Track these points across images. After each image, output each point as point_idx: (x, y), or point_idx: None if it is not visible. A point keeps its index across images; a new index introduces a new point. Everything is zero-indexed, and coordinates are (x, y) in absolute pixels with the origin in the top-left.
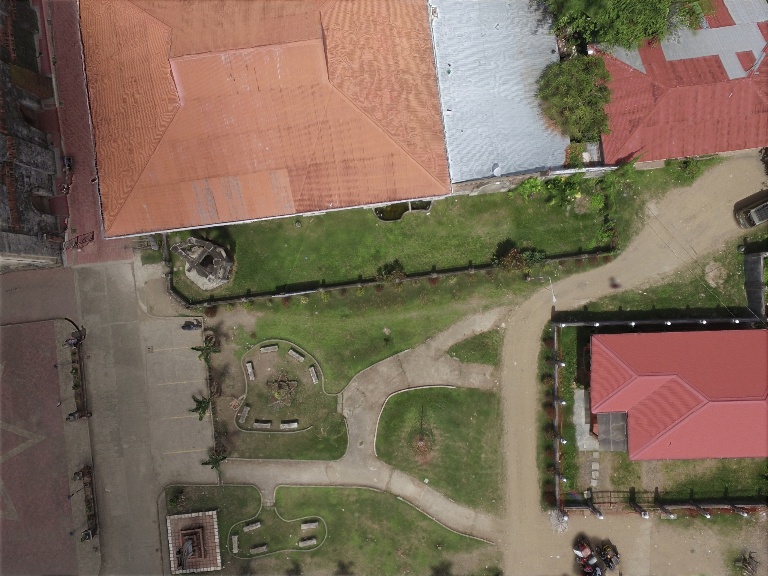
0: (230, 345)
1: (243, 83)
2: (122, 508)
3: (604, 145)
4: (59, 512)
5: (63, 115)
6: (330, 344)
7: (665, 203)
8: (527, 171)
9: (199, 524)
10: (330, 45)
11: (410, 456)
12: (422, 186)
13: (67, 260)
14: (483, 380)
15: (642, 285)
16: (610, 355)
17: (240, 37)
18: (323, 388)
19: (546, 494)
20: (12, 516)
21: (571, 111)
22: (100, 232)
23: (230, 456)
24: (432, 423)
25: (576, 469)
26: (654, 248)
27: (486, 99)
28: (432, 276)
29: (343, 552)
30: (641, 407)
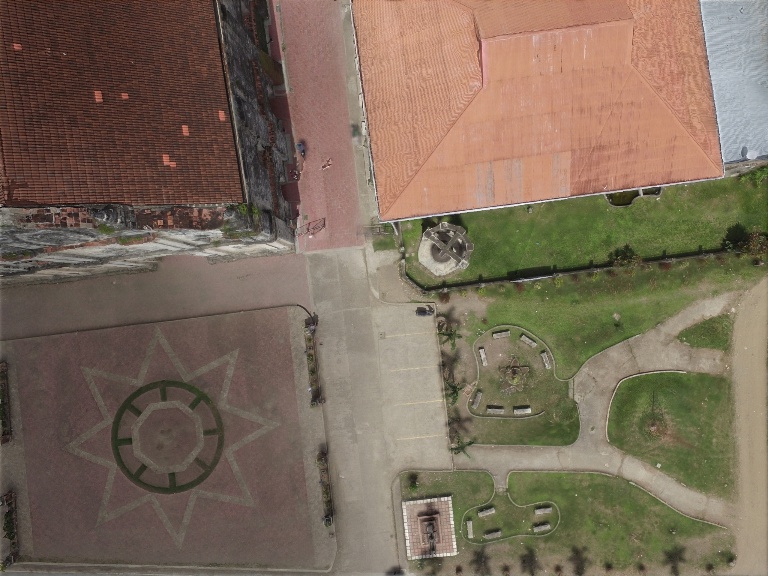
0: (462, 331)
1: (547, 64)
2: (356, 494)
3: None
4: (295, 498)
5: (293, 101)
6: (561, 329)
7: None
8: None
9: (435, 510)
10: None
11: (642, 441)
12: (697, 168)
13: (299, 246)
14: (713, 365)
15: None
16: None
17: (547, 18)
18: (555, 373)
19: None
20: (248, 503)
21: None
22: (331, 218)
23: None
24: (663, 408)
25: None
26: None
27: (735, 83)
28: (667, 261)
29: (577, 537)
30: None
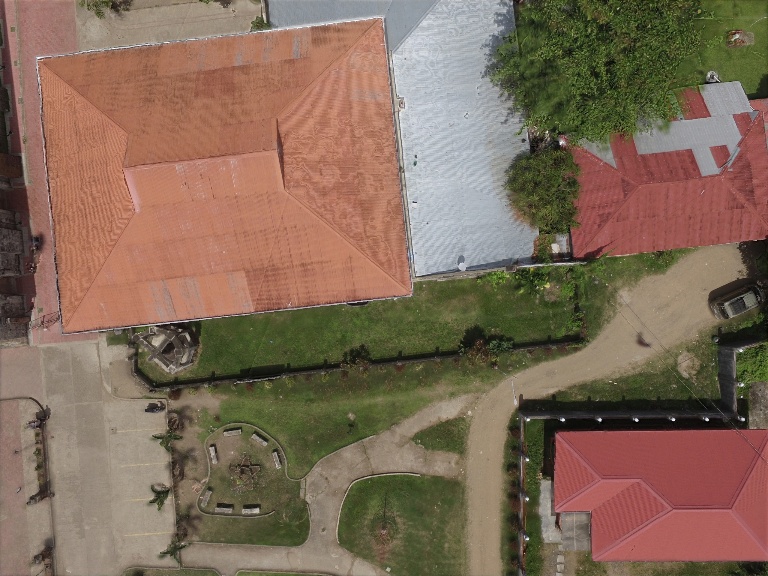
0: (194, 428)
1: (198, 191)
2: None
3: (573, 238)
4: None
5: (32, 194)
6: (294, 428)
7: (638, 291)
8: (494, 263)
9: None
10: (287, 152)
11: (372, 544)
12: (382, 287)
13: (33, 339)
14: (448, 468)
15: (612, 375)
16: (574, 455)
17: (195, 146)
18: (286, 473)
19: None
20: None
21: (537, 209)
22: None
23: (191, 539)
24: (395, 511)
25: (541, 562)
26: (625, 337)
27: (453, 190)
28: (397, 364)
29: None
30: (605, 508)
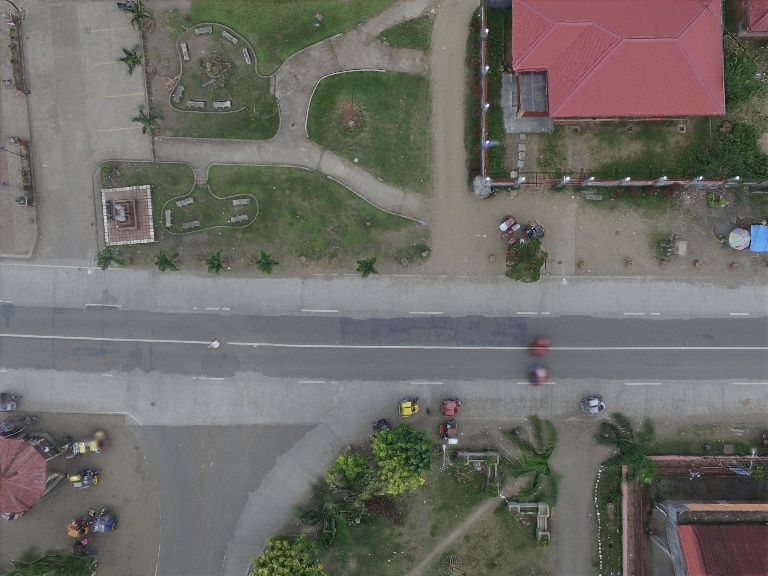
0: (166, 28)
1: None
2: (59, 183)
3: None
4: None
5: None
6: (263, 28)
7: None
8: None
9: (133, 197)
10: None
11: (340, 136)
12: None
13: None
14: (413, 65)
15: None
16: (530, 9)
17: None
18: (256, 70)
19: (473, 171)
20: None
21: None
22: None
23: (164, 135)
24: (362, 105)
25: (503, 149)
26: None
27: None
28: None
29: (274, 228)
30: (560, 60)
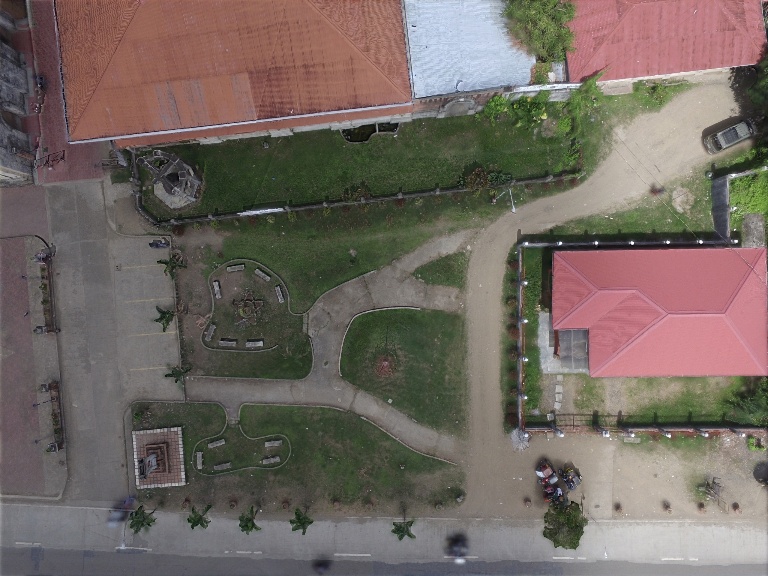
0: (197, 264)
1: None
2: (89, 423)
3: (569, 64)
4: (27, 426)
5: (36, 35)
6: (296, 264)
7: (633, 128)
8: (491, 89)
9: (164, 440)
10: None
11: (374, 376)
12: (382, 93)
13: (38, 178)
14: (448, 302)
15: (608, 210)
16: (571, 271)
17: None
18: (289, 308)
19: (509, 415)
20: None
21: (533, 24)
22: (71, 151)
23: (196, 374)
24: (397, 344)
25: (540, 391)
26: (621, 173)
27: (451, 16)
28: (398, 196)
29: (306, 470)
30: (602, 323)
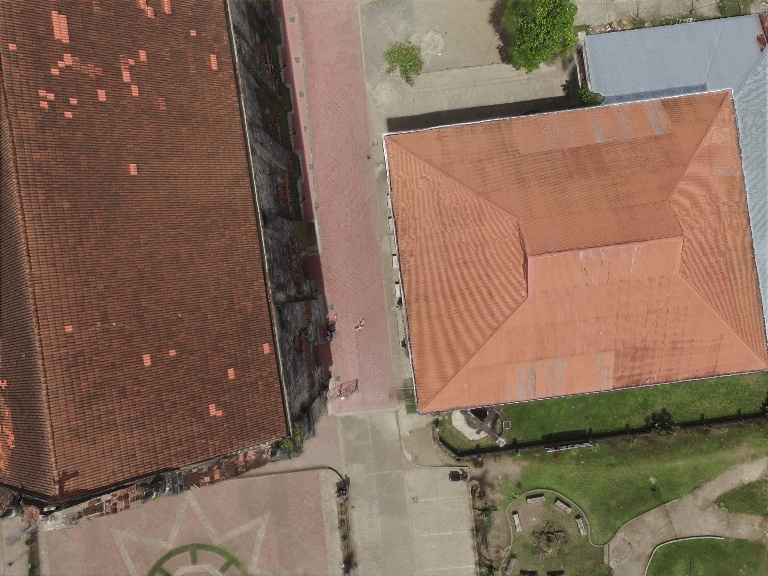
0: (495, 495)
1: (594, 276)
2: None
3: None
4: None
5: (326, 261)
6: (596, 494)
7: None
8: None
9: None
10: None
11: None
12: (743, 362)
13: (331, 408)
14: (752, 531)
15: None
16: None
17: (594, 231)
18: (590, 539)
19: None
20: None
21: None
22: (364, 380)
23: None
24: (701, 575)
25: None
26: None
27: None
28: (705, 428)
29: None
30: None
